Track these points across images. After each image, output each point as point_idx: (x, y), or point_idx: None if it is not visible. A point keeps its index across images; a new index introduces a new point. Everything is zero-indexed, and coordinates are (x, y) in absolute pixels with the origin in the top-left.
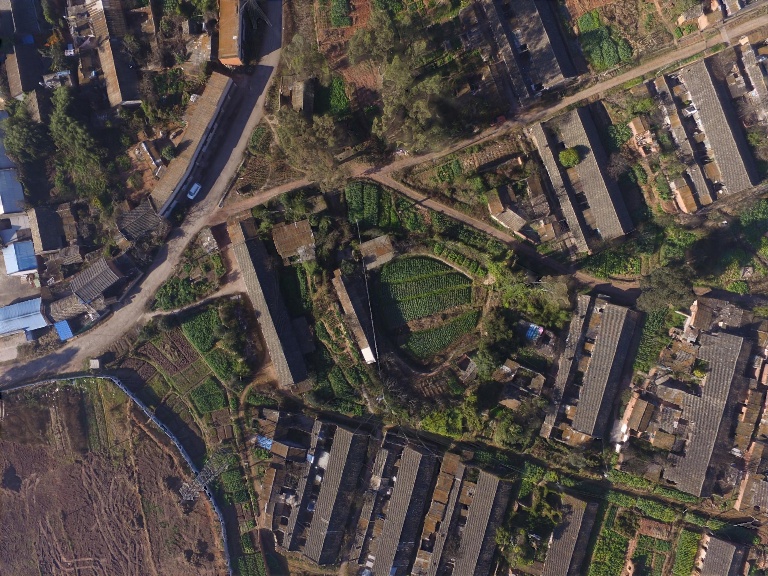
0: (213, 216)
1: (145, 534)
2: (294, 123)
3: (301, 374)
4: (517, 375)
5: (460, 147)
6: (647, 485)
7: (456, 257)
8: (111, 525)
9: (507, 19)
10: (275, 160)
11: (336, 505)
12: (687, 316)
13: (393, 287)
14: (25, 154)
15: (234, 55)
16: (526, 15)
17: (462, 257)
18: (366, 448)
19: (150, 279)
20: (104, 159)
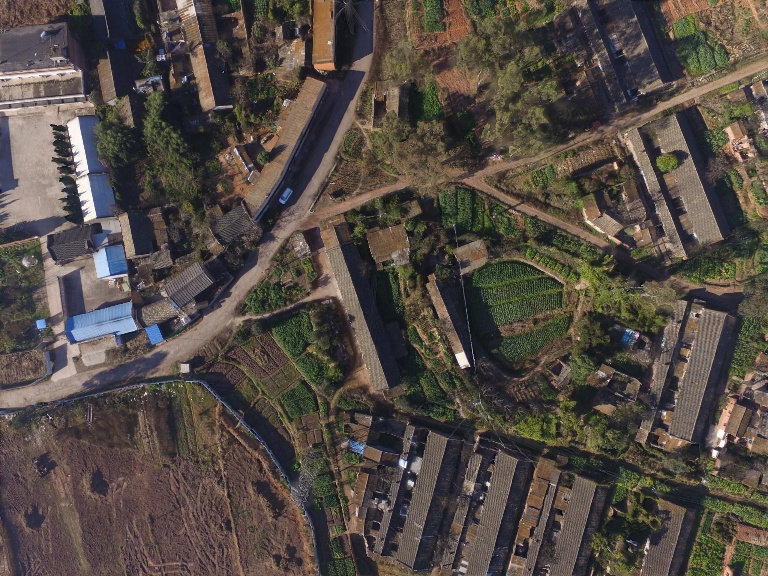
0: (304, 221)
1: (233, 539)
2: (397, 128)
3: (395, 379)
4: (613, 380)
5: (554, 152)
6: (745, 491)
7: (548, 262)
8: (199, 529)
9: (603, 24)
10: (367, 165)
11: (430, 510)
12: None
13: (484, 292)
14: (117, 159)
15: (329, 60)
16: (623, 20)
17: (554, 262)
18: (459, 453)
19: (240, 283)
20: (195, 164)
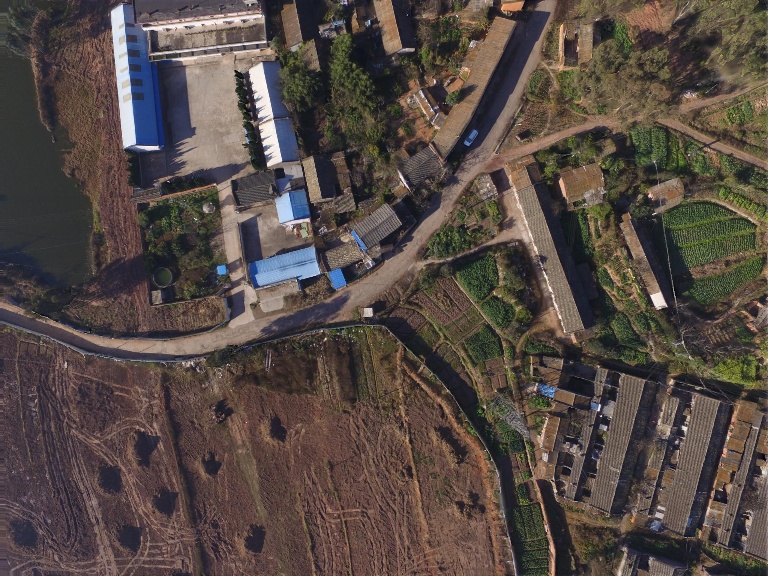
0: (489, 163)
1: (414, 485)
2: (607, 60)
3: (589, 320)
4: None
5: (751, 88)
6: None
7: (743, 201)
8: (379, 476)
9: None
10: (555, 105)
11: (627, 453)
12: None
13: (675, 233)
14: (302, 103)
15: None
16: None
17: (749, 201)
18: (654, 396)
19: (422, 227)
20: (378, 107)
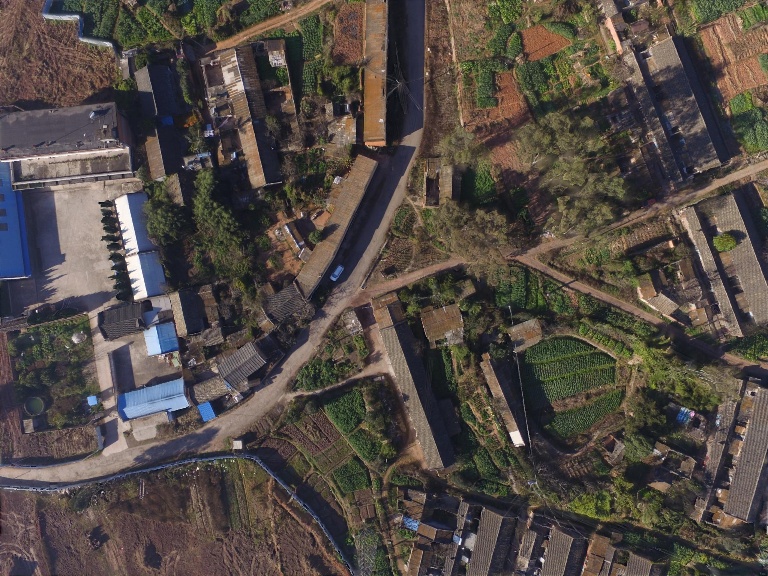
0: (355, 297)
1: None
2: None
3: (449, 457)
4: (668, 459)
5: (608, 229)
6: None
7: (601, 338)
8: None
9: (659, 101)
10: (419, 242)
11: None
12: None
13: (537, 367)
14: (167, 237)
15: (381, 138)
16: (680, 98)
17: (607, 338)
18: (513, 530)
19: (291, 360)
20: (245, 241)
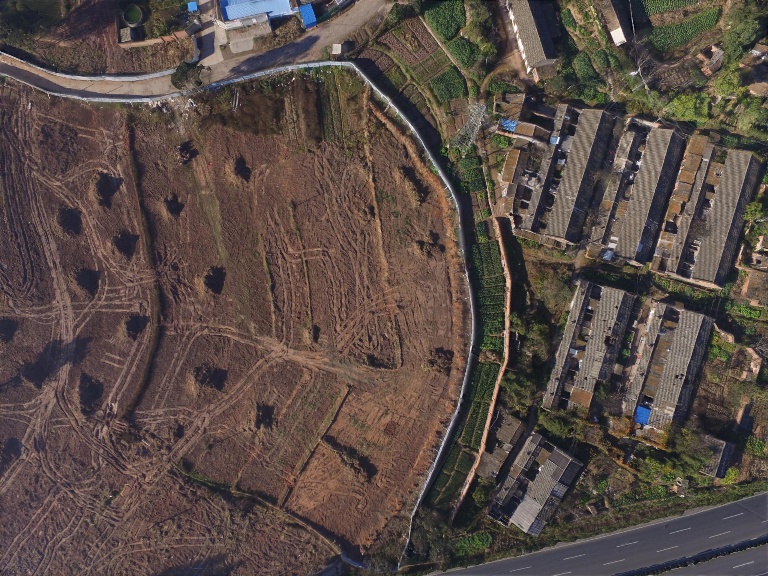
0: None
1: (376, 225)
2: None
3: (551, 53)
4: (767, 57)
5: None
6: None
7: None
8: (342, 215)
9: None
10: None
11: (583, 182)
12: None
13: None
14: None
15: None
16: None
17: None
18: (611, 131)
19: None
20: None
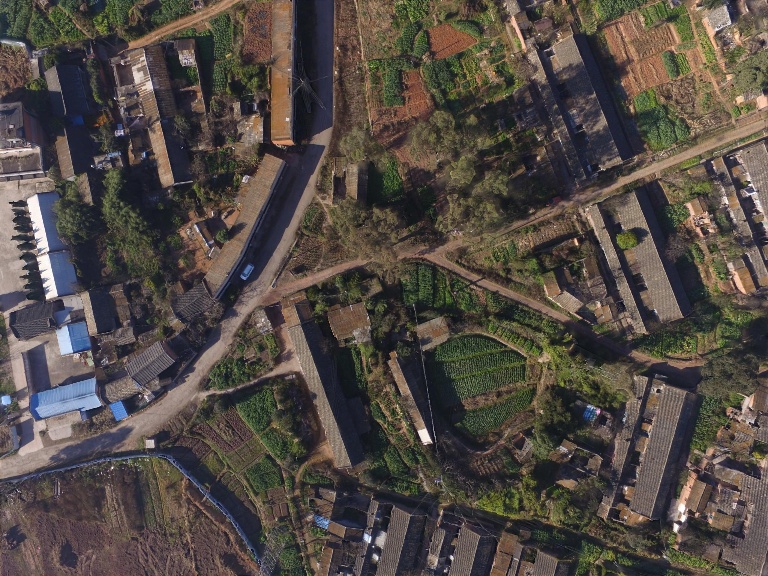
0: (266, 296)
1: None
2: (353, 213)
3: (358, 456)
4: (574, 456)
5: (515, 227)
6: (705, 565)
7: (511, 336)
8: None
9: (563, 99)
10: (328, 241)
11: None
12: (745, 396)
13: (447, 366)
14: (77, 236)
15: (287, 137)
16: (583, 96)
17: (517, 336)
18: (423, 527)
19: (204, 359)
20: (156, 240)
